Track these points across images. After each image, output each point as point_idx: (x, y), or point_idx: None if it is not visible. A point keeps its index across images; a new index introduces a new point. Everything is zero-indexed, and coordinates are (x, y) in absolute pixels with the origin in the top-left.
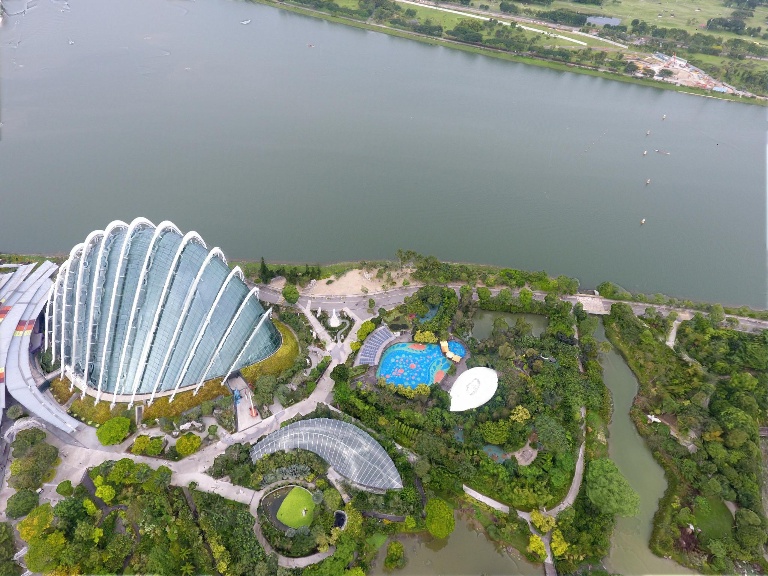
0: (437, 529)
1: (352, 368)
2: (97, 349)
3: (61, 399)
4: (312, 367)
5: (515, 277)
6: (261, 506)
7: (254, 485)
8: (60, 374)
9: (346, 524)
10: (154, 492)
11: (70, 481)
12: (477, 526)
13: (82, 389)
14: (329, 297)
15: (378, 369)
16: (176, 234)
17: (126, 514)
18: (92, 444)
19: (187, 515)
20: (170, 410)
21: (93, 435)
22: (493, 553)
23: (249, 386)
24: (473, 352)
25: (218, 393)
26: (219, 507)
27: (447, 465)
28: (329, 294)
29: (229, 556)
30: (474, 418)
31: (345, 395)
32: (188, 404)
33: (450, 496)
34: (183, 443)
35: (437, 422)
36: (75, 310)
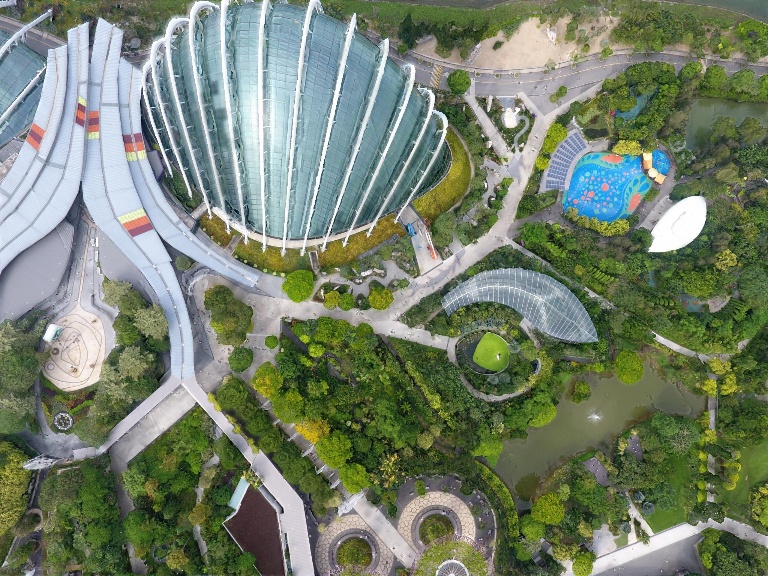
0: (628, 379)
1: (539, 196)
2: (249, 191)
3: (221, 242)
4: (489, 191)
5: (761, 41)
6: (463, 357)
7: (451, 336)
8: (207, 211)
9: (541, 370)
10: (363, 349)
11: (275, 336)
12: (654, 365)
13: (241, 232)
14: (498, 73)
15: (565, 192)
16: (327, 20)
17: (342, 367)
18: (276, 293)
19: (394, 363)
20: (346, 255)
21: (273, 283)
22: (657, 378)
23: (426, 223)
24: (682, 170)
25: (392, 232)
26: (431, 366)
27: (639, 314)
28: (498, 67)
29: (440, 397)
30: (676, 265)
31: (538, 238)
32: (363, 247)
33: (635, 341)
34: (378, 300)
35: (638, 272)
36: (207, 141)
